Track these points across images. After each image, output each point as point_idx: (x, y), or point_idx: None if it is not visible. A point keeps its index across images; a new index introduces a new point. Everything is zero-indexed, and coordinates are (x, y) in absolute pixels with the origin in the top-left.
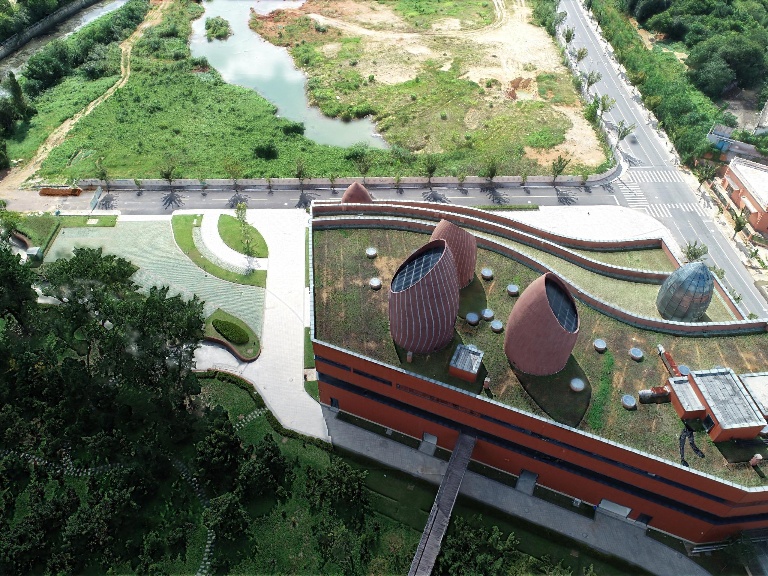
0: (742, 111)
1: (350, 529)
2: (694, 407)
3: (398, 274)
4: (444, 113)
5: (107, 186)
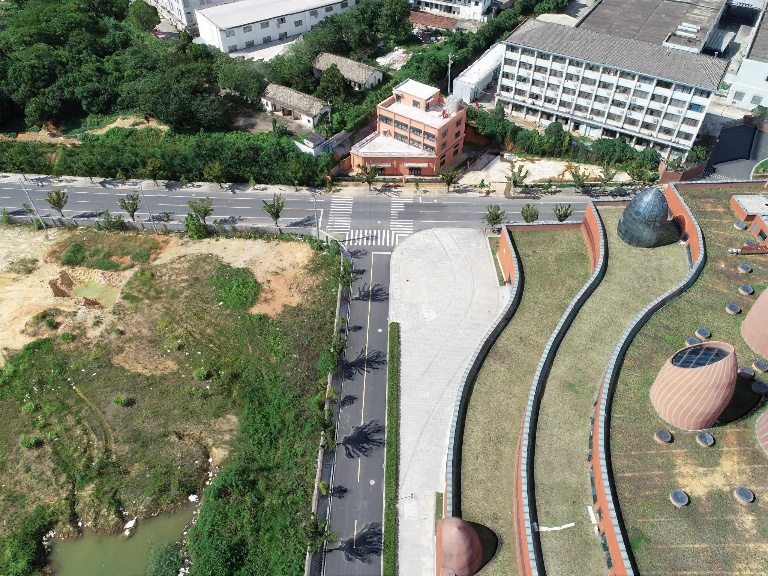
0: (261, 121)
1: None
2: None
3: None
4: (123, 398)
5: None
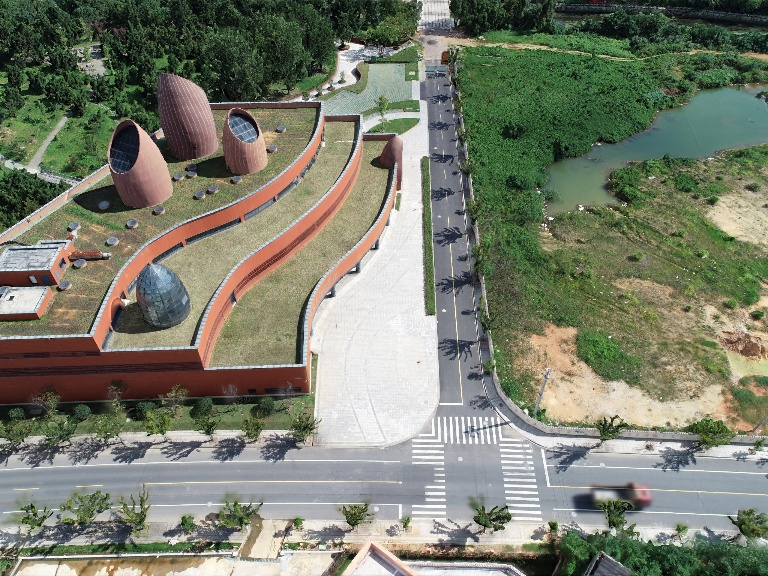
0: None
1: None
2: None
3: None
4: (636, 254)
5: (453, 71)
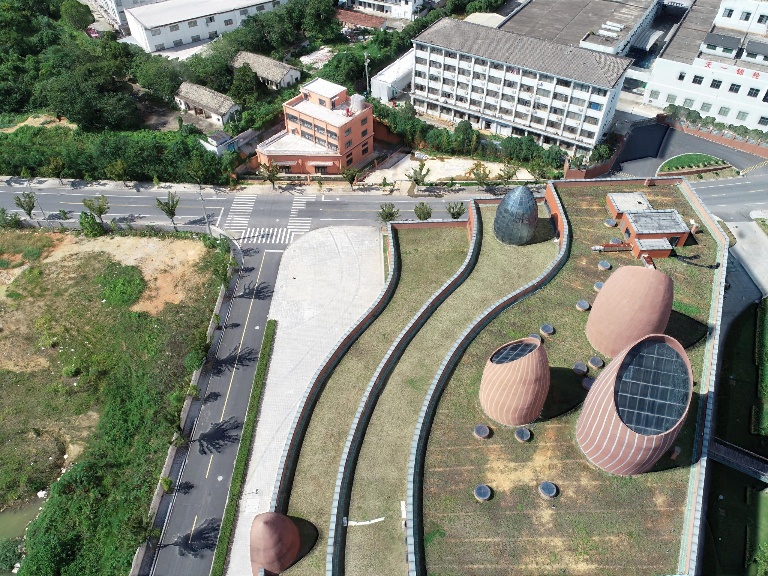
0: (173, 120)
1: None
2: (667, 243)
3: (627, 425)
4: None
5: None
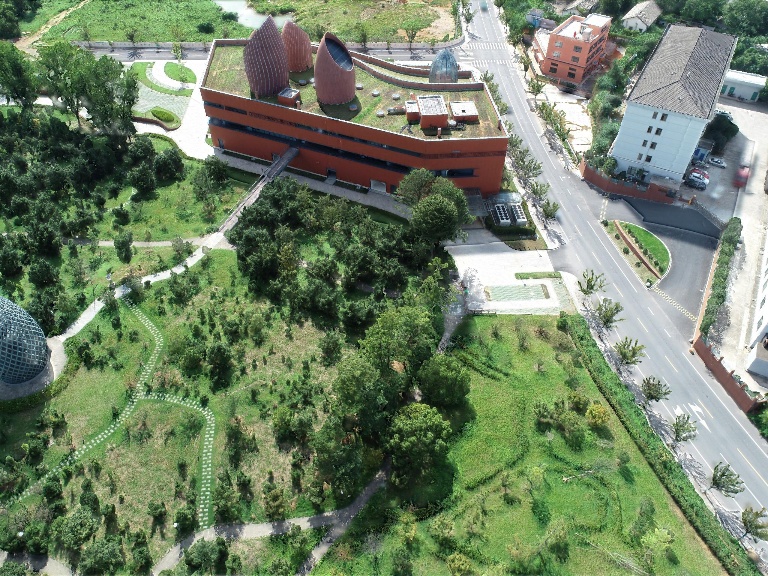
0: (563, 5)
1: (216, 191)
2: (413, 111)
3: None
4: (345, 9)
5: (89, 46)
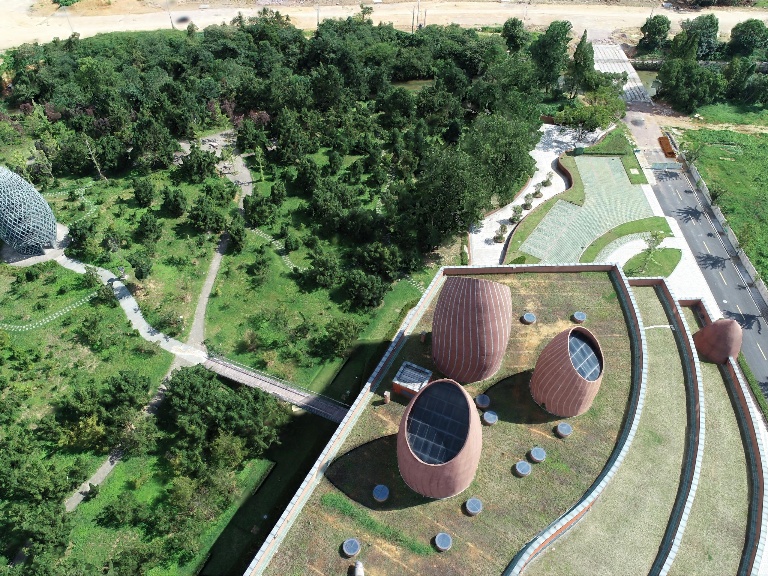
0: None
1: (310, 347)
2: None
3: None
4: None
5: (688, 170)
